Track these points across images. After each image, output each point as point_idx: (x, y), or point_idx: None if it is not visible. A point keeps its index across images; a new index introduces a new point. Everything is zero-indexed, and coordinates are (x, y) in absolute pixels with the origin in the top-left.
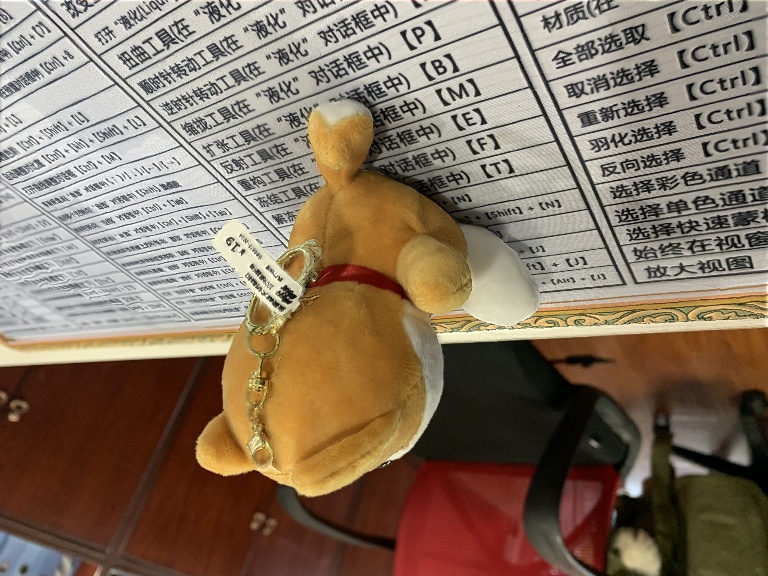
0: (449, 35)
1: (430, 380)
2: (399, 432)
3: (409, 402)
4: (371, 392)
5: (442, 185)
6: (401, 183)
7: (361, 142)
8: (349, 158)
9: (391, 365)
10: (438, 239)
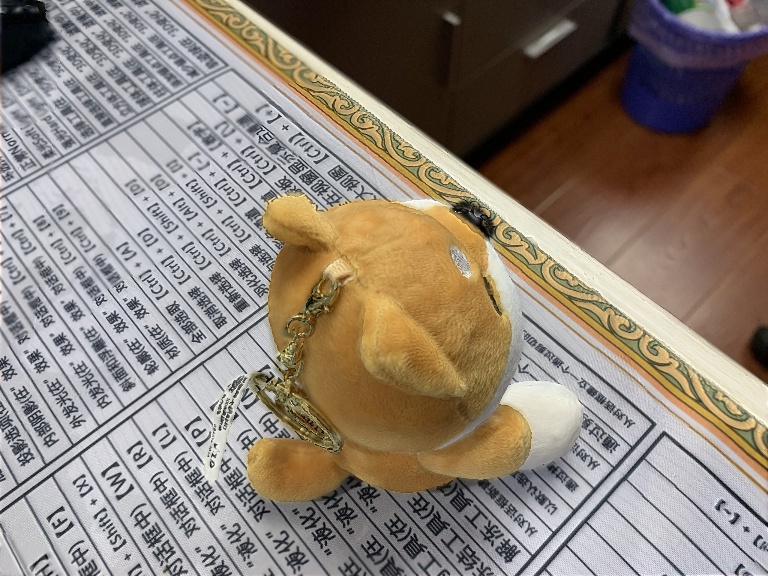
0: (194, 412)
1: None
2: None
3: None
4: None
5: None
6: None
7: None
8: None
9: None
10: None
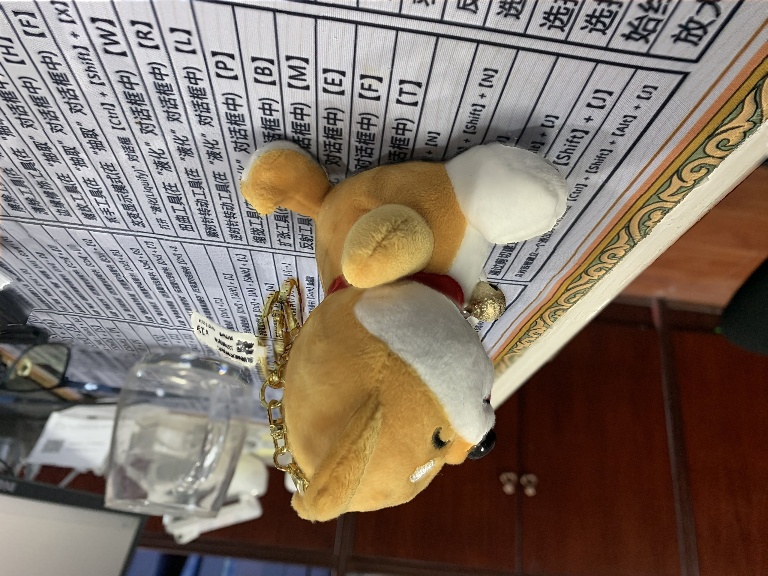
0: (231, 47)
1: (409, 351)
2: (398, 419)
3: (383, 386)
4: (334, 396)
5: (404, 142)
6: (364, 171)
7: (277, 175)
8: (275, 195)
9: (343, 360)
10: (395, 202)
